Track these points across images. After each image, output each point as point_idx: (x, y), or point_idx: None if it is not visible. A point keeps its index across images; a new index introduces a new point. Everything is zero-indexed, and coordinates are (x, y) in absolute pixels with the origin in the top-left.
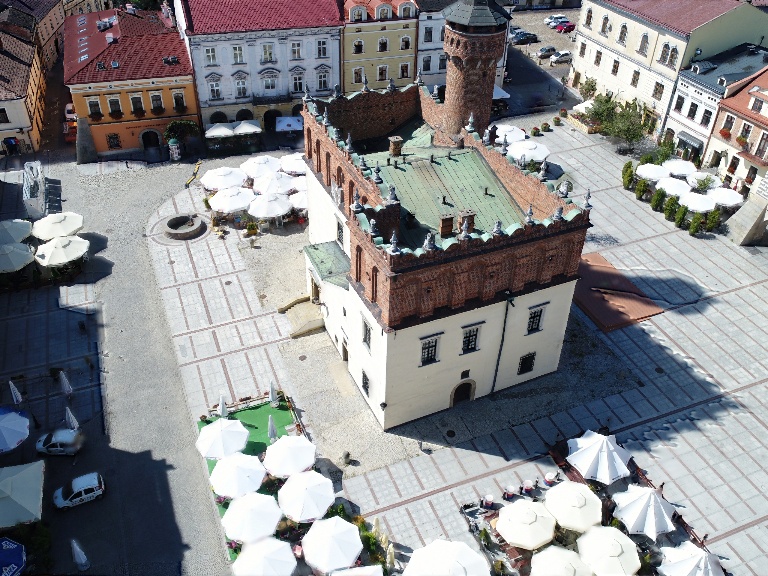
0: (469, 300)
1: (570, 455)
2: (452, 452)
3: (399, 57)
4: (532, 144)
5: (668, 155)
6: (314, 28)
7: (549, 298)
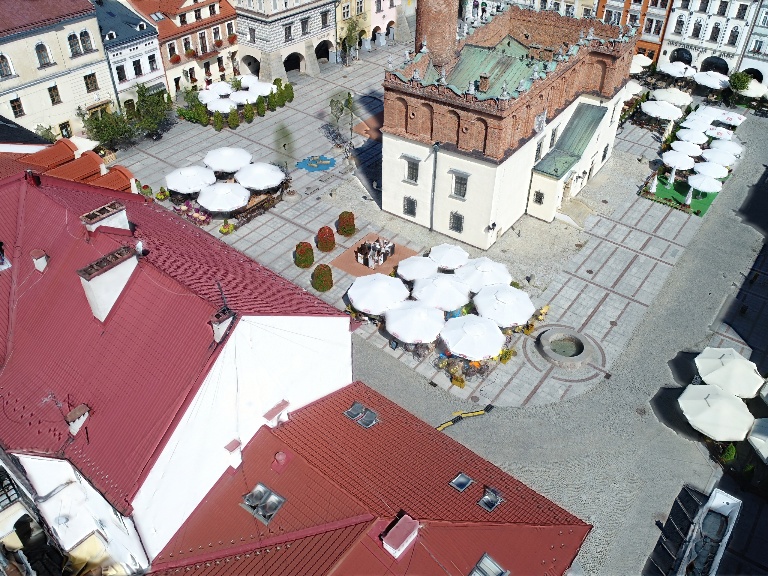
0: None
1: None
2: None
3: None
4: (228, 149)
5: None
6: None
7: None
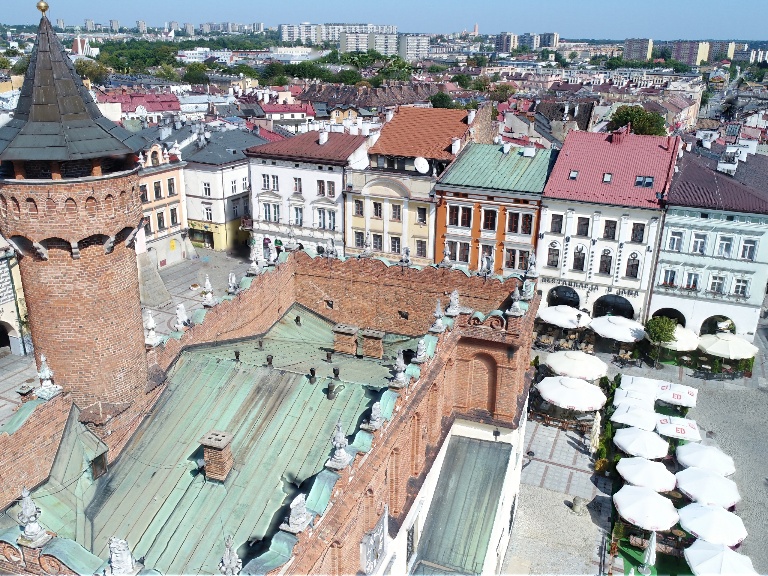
0: None
1: None
2: None
3: None
4: None
5: None
6: None
7: None
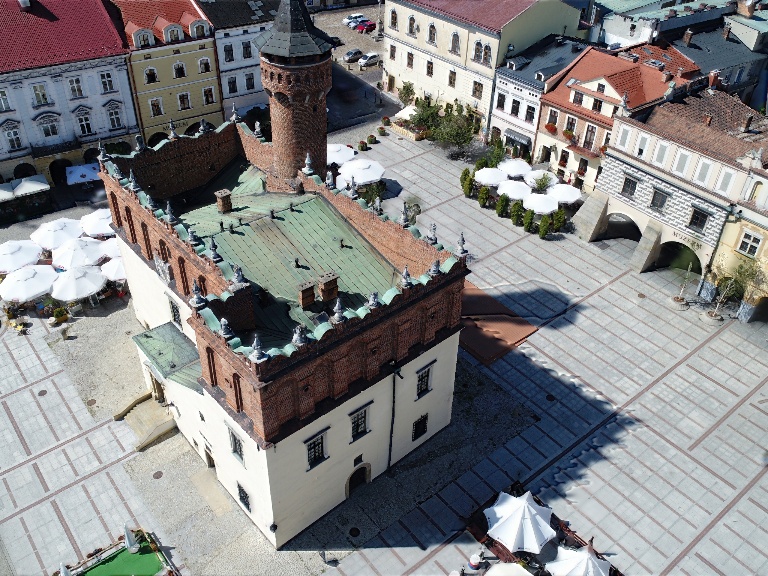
0: (352, 383)
1: (491, 529)
2: (361, 556)
3: (200, 81)
4: (365, 163)
5: (501, 156)
6: (93, 60)
7: (435, 356)
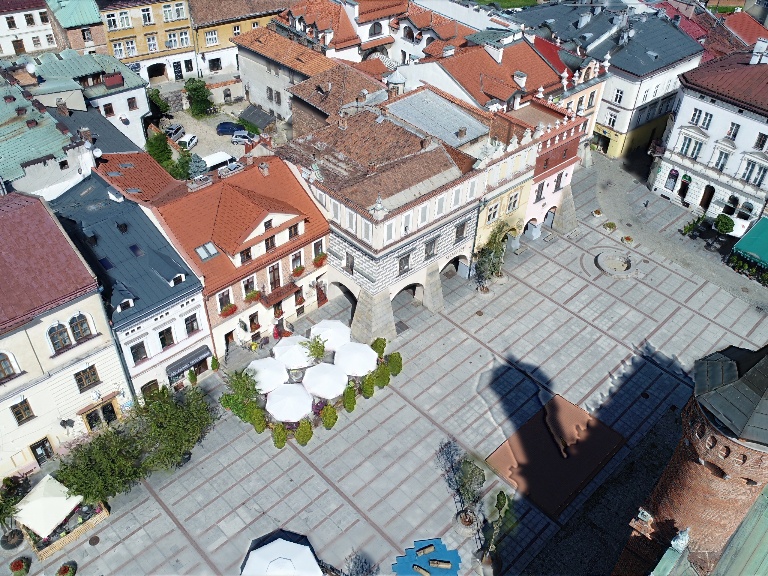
0: None
1: None
2: None
3: None
4: (282, 565)
5: None
6: None
7: None
